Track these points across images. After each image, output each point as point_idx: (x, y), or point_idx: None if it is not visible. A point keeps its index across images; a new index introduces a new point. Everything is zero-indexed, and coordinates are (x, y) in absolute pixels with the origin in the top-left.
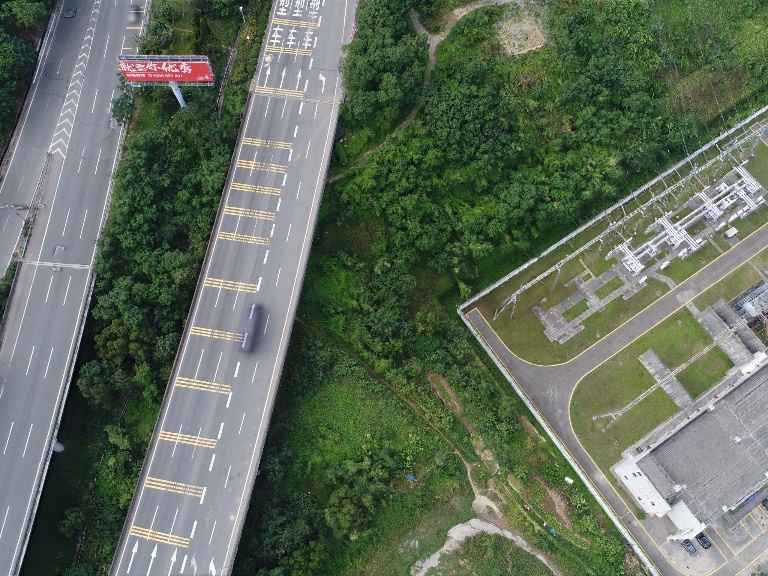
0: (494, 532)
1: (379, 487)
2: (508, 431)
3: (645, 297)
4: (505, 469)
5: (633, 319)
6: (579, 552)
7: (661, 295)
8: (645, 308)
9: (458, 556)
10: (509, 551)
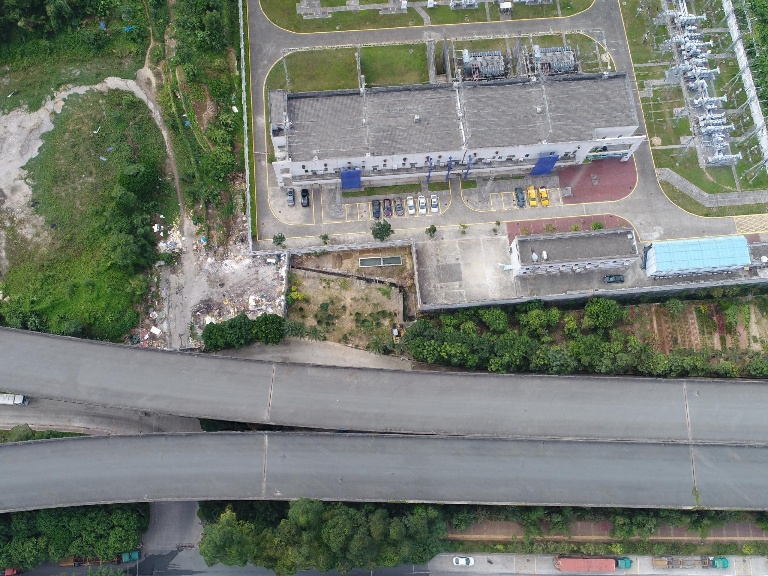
0: (141, 97)
1: (63, 3)
2: (203, 39)
3: (398, 20)
4: (178, 58)
5: (375, 30)
6: (196, 146)
7: (412, 25)
8: (391, 27)
9: (101, 95)
10: (143, 115)
